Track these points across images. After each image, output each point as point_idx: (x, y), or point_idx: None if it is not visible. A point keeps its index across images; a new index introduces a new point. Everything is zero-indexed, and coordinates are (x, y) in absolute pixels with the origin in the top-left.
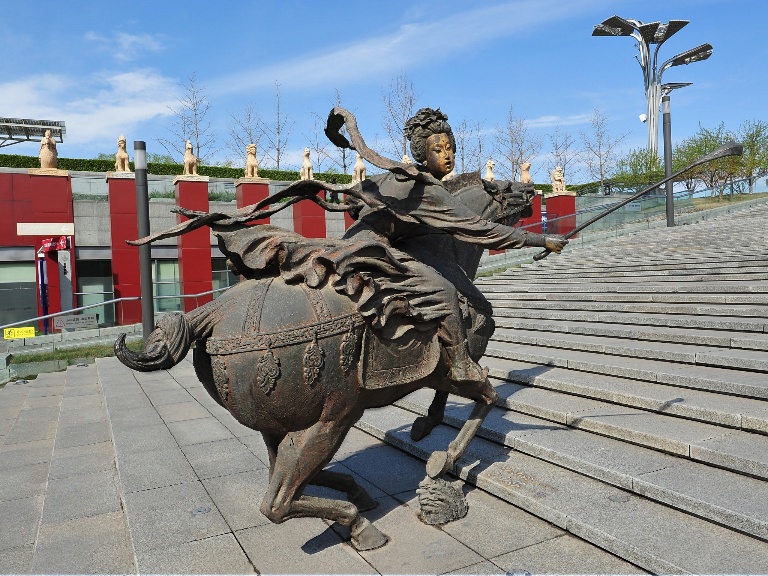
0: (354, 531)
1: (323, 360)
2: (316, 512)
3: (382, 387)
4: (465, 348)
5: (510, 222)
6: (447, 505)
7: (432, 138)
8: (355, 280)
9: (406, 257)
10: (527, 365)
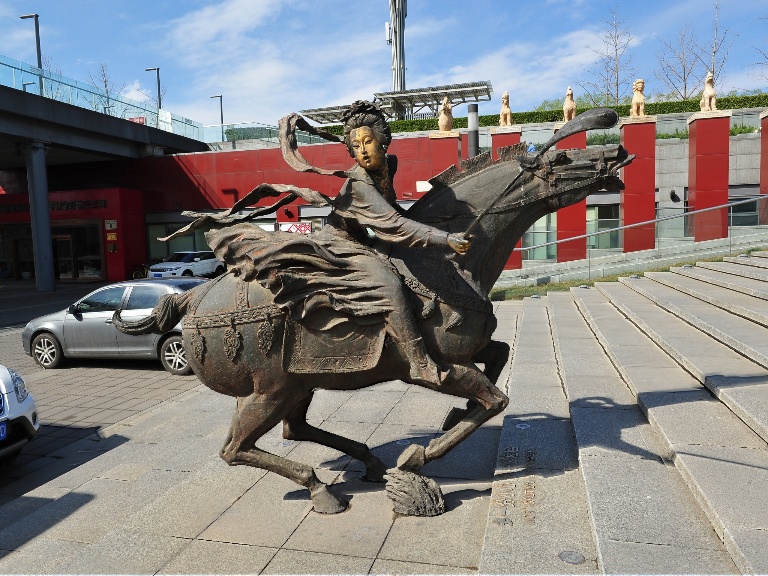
0: (311, 493)
1: (241, 342)
2: (265, 466)
3: (311, 373)
4: (417, 347)
5: (565, 200)
6: (412, 499)
7: (351, 134)
8: (272, 275)
9: (352, 251)
10: (755, 371)
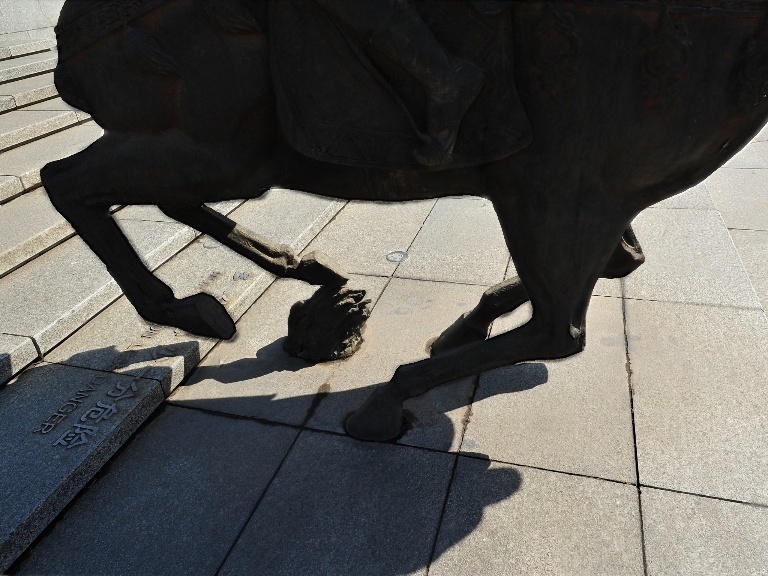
0: None
1: None
2: None
3: None
4: None
5: None
6: None
7: None
8: None
9: None
10: None
